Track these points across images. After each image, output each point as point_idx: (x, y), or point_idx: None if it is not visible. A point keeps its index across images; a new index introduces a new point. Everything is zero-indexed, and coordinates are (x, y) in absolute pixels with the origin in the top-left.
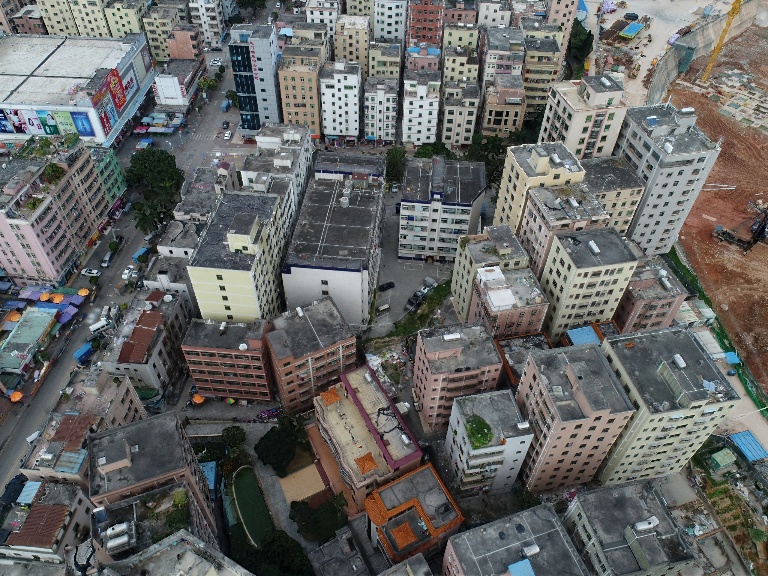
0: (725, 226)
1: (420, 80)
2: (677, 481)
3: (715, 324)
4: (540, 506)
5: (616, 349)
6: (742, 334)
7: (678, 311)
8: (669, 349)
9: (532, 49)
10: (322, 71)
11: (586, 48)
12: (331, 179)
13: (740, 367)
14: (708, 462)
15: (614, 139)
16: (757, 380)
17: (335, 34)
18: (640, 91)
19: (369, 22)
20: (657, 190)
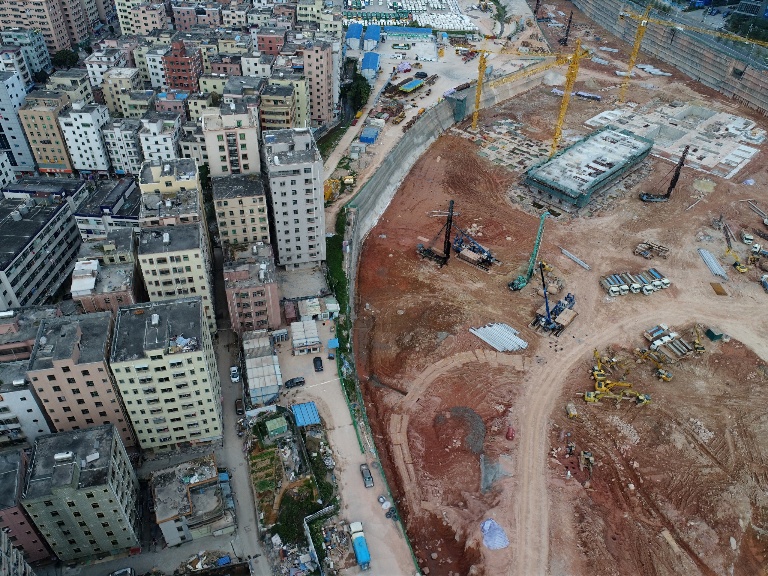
0: (434, 245)
1: (153, 119)
2: (232, 447)
3: (342, 318)
4: (11, 451)
5: (125, 316)
6: (403, 334)
7: (306, 306)
8: (174, 315)
9: (269, 94)
10: (64, 111)
11: (356, 98)
12: (20, 198)
13: (343, 352)
14: (267, 430)
15: (256, 157)
16: (397, 372)
17: (101, 83)
18: (397, 134)
19: (136, 73)
20: (278, 198)
